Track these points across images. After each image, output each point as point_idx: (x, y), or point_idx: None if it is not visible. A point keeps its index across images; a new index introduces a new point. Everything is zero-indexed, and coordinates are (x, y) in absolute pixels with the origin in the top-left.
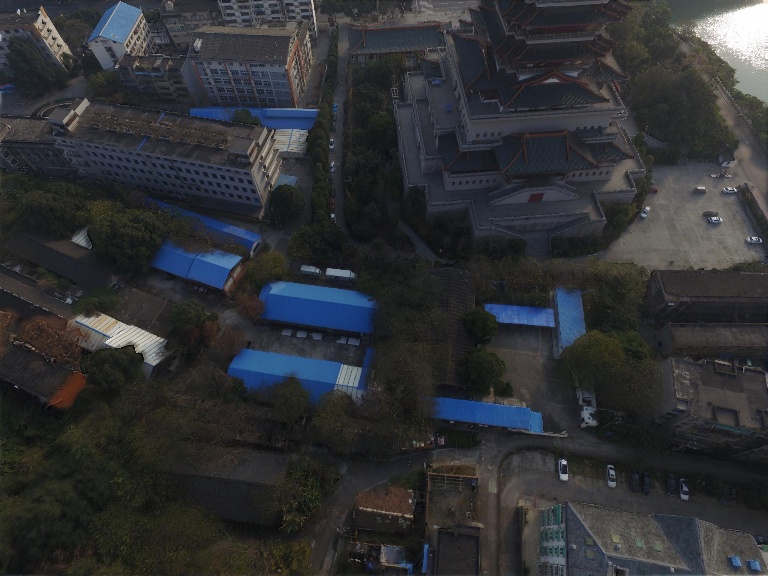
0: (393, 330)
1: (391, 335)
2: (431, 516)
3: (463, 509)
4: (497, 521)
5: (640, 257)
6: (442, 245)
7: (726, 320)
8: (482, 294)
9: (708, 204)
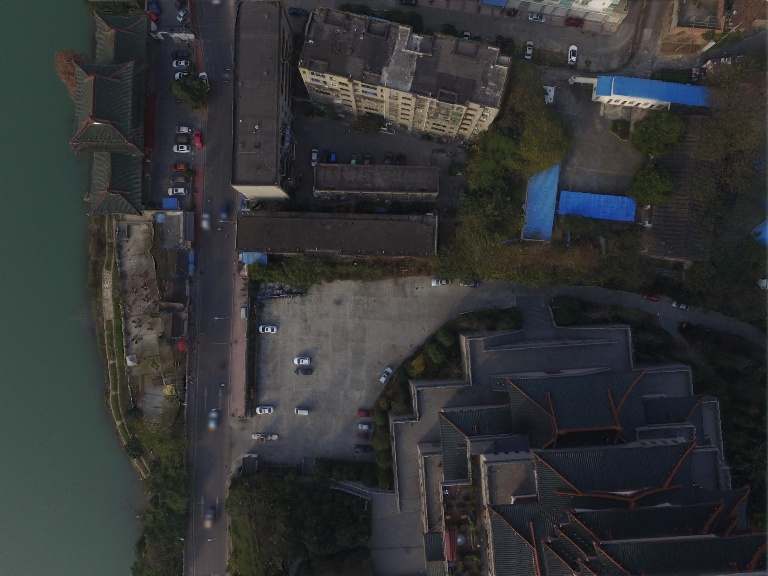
0: (767, 165)
1: (767, 161)
2: (715, 2)
3: (686, 7)
4: (651, 3)
5: (410, 309)
6: (659, 320)
7: (359, 210)
8: (640, 230)
9: (300, 389)
